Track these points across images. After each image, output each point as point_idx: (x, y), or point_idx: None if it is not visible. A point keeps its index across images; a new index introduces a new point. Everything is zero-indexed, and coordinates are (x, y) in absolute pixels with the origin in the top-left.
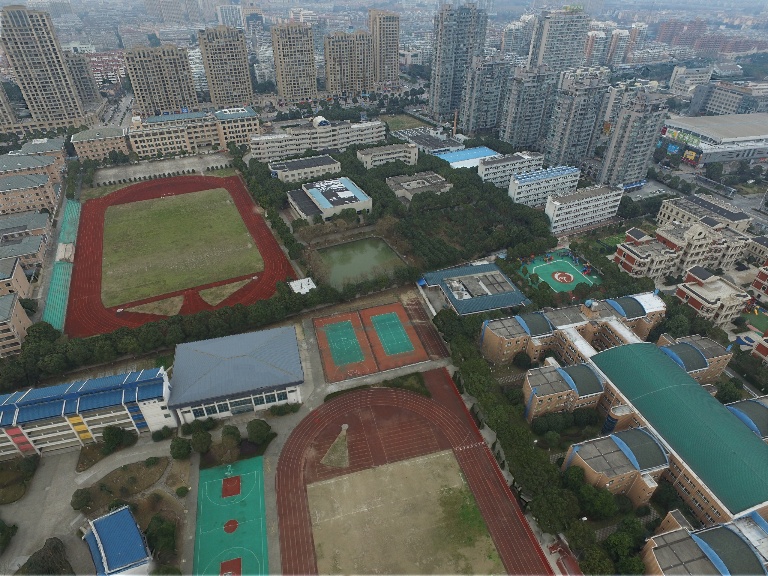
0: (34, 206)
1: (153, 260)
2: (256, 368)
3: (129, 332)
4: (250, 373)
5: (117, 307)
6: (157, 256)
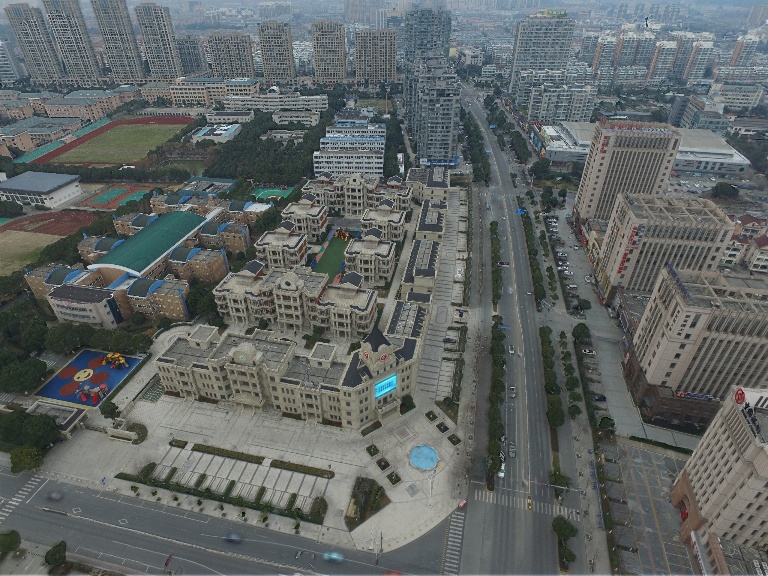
0: (85, 117)
1: (97, 149)
2: (35, 183)
3: (24, 165)
4: (31, 184)
5: (53, 163)
6: (102, 148)
